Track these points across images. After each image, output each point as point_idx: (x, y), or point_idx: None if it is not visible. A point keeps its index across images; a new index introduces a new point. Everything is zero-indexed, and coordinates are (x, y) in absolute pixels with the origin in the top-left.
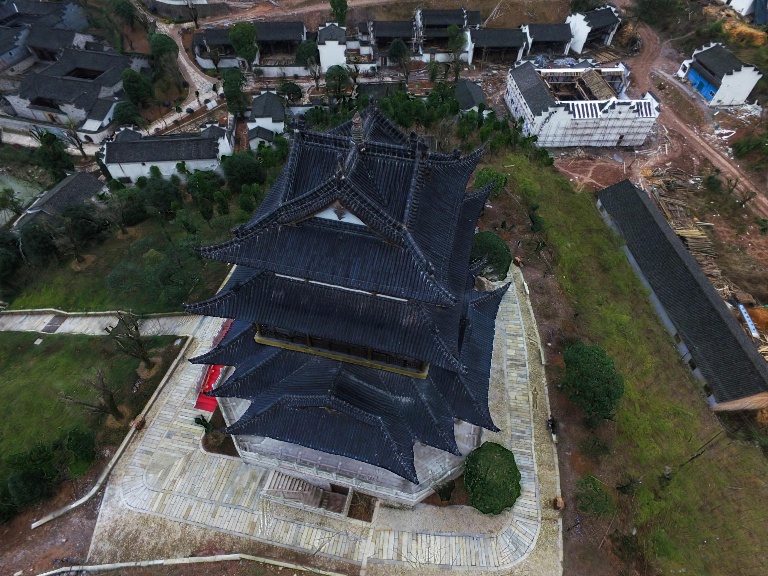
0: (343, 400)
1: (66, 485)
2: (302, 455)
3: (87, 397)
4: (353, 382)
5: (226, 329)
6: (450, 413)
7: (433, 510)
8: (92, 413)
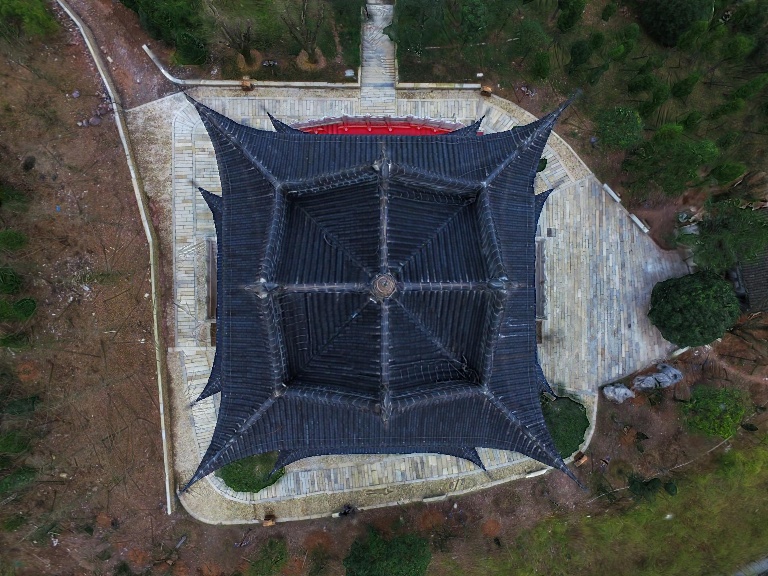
0: None
1: None
2: None
3: (276, 12)
4: None
5: (366, 123)
6: None
7: None
8: (257, 29)
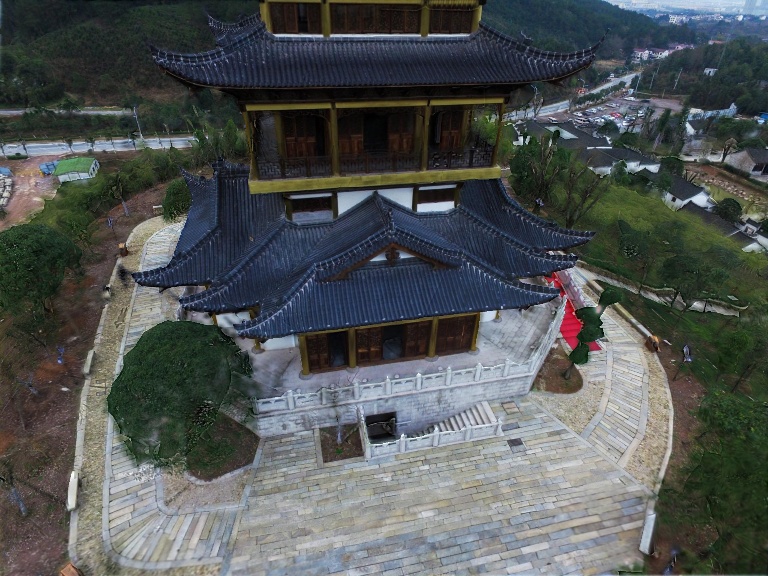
0: None
1: None
2: None
3: None
4: None
5: None
6: None
7: None
8: None
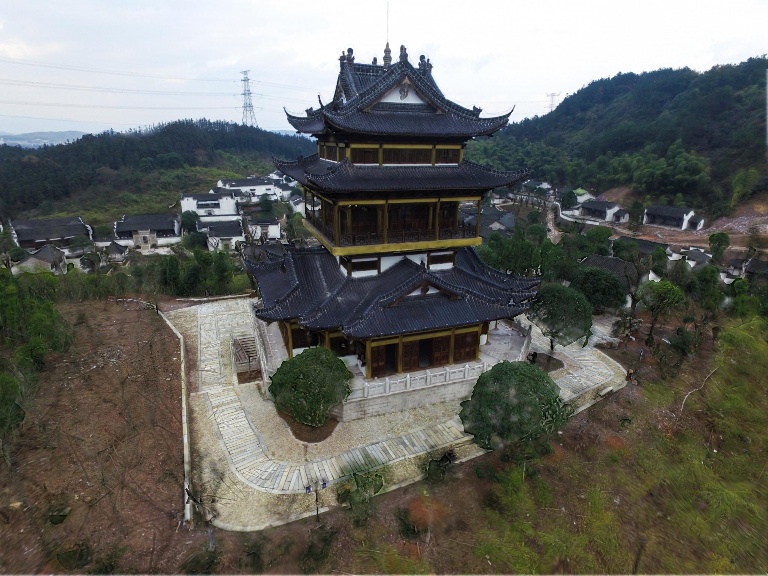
0: (293, 259)
1: (204, 296)
2: (268, 328)
3: None
4: (315, 265)
5: None
6: (343, 322)
7: (272, 411)
8: None
